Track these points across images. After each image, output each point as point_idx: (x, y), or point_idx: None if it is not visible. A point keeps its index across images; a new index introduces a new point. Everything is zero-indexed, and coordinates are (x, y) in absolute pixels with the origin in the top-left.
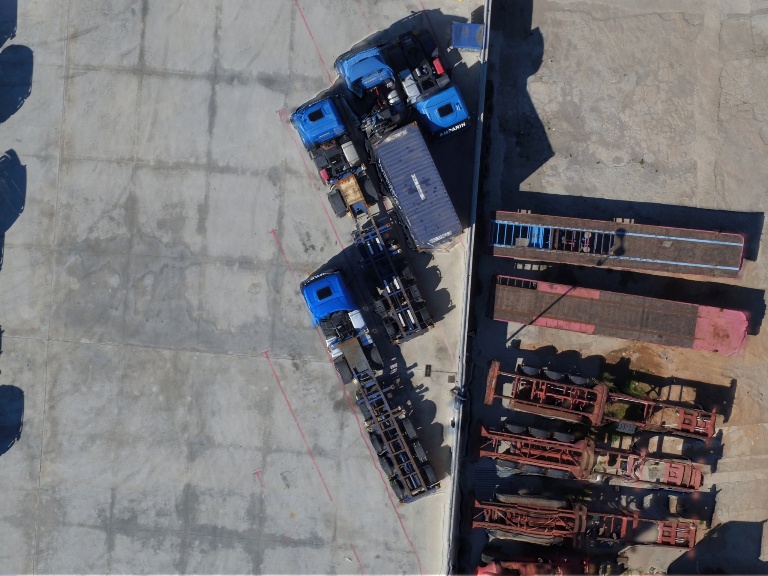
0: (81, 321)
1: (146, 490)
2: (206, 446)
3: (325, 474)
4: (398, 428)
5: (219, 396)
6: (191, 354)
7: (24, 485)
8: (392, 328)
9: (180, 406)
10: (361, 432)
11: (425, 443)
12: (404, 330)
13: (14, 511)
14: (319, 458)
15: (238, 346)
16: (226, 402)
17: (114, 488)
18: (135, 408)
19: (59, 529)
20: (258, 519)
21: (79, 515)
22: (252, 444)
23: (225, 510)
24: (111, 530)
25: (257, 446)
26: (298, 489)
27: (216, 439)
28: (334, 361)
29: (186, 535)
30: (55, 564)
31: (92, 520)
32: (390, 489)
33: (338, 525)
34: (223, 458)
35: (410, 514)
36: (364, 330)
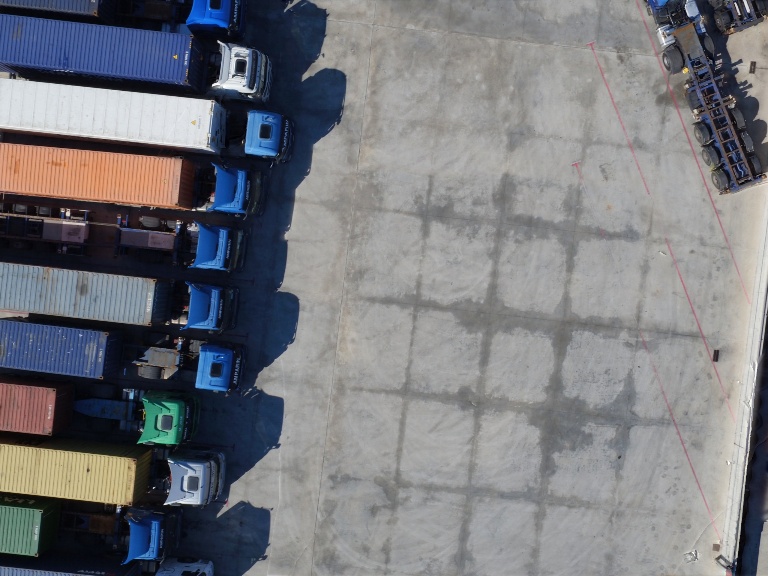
0: (407, 7)
1: (464, 178)
2: (526, 136)
3: (644, 168)
4: (728, 116)
5: (542, 86)
6: (516, 44)
7: (342, 169)
8: (727, 16)
9: (502, 95)
10: (684, 125)
11: (751, 135)
12: (739, 19)
13: (331, 195)
14: (639, 151)
15: (563, 37)
16: (548, 93)
17: (432, 175)
18: (457, 96)
19: (375, 214)
20: (574, 211)
21: (396, 201)
22: (572, 135)
23: (542, 201)
24: (427, 217)
25: (577, 138)
26: (616, 182)
27: (537, 129)
28: (665, 49)
29: (501, 224)
30: (369, 249)
31: (408, 206)
32: (710, 183)
33: (654, 219)
34: (543, 149)
35: (727, 210)
36: (701, 16)
